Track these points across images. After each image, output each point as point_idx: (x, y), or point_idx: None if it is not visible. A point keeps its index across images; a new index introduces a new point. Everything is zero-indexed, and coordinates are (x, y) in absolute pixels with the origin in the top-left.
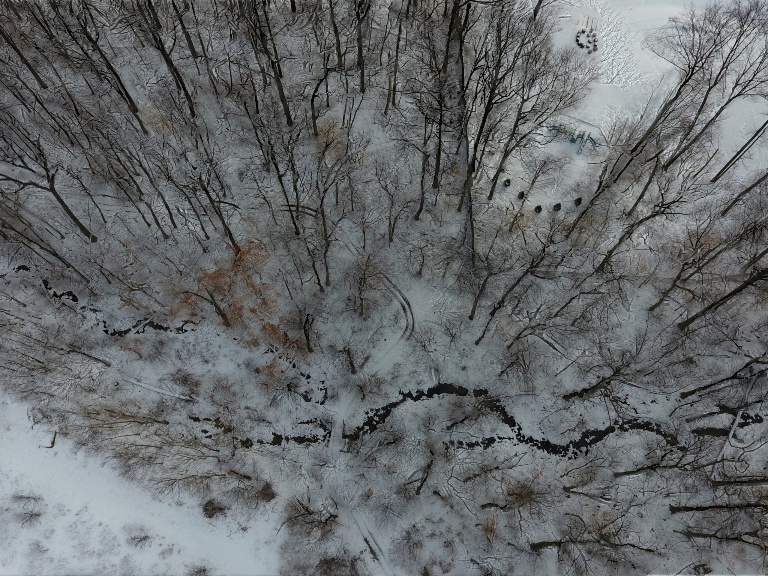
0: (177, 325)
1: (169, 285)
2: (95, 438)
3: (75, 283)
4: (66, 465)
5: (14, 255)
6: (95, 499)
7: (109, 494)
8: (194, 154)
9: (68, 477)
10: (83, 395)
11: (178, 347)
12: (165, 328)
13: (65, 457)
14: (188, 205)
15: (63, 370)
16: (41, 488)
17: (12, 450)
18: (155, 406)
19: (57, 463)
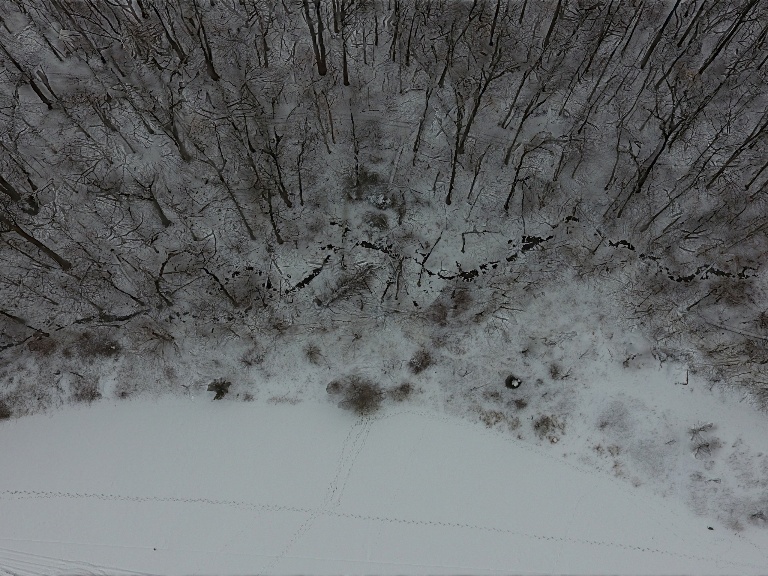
0: (738, 271)
1: (724, 233)
2: (724, 375)
3: (628, 232)
4: (705, 401)
5: (564, 206)
6: (745, 432)
7: (756, 427)
8: (711, 108)
9: (711, 412)
10: (689, 336)
11: (748, 291)
12: (727, 274)
13: (702, 393)
14: (716, 157)
15: (663, 312)
16: (691, 422)
17: (649, 387)
18: (744, 347)
19: (696, 399)
